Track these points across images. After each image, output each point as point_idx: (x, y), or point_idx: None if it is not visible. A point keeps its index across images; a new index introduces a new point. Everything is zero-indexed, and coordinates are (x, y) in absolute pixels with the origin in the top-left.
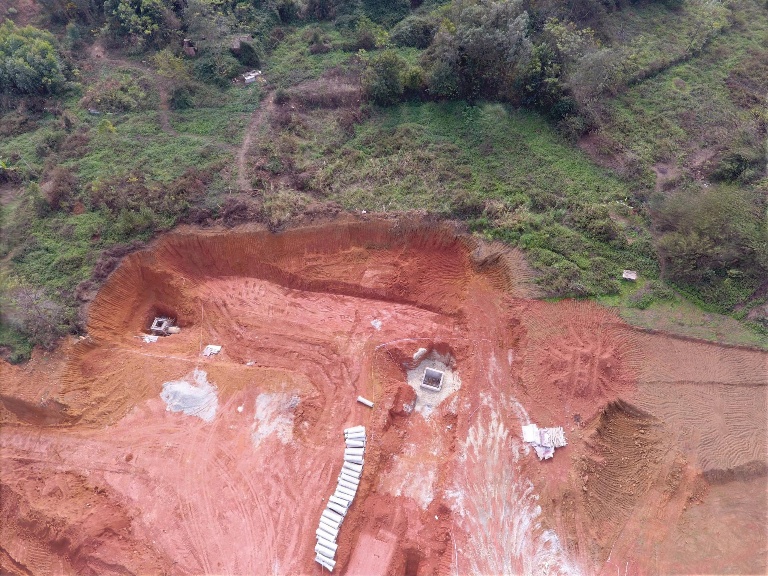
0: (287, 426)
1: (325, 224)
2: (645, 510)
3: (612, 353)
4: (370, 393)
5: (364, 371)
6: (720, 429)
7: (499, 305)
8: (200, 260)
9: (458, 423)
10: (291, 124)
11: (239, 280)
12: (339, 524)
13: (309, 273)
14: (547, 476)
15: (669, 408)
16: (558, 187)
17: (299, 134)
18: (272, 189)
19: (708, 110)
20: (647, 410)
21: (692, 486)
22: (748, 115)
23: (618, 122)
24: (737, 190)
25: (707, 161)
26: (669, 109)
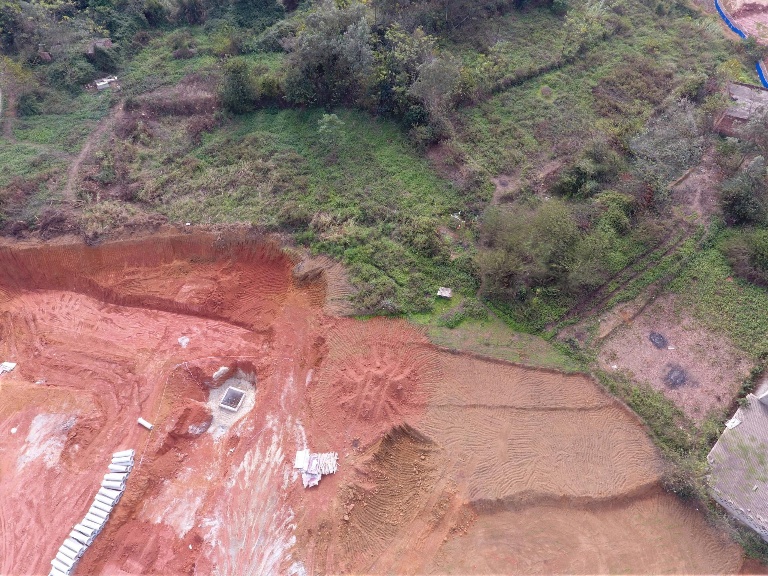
0: (56, 449)
1: (145, 237)
2: (404, 541)
3: (406, 375)
4: (154, 414)
5: (155, 391)
6: (500, 456)
7: (311, 322)
8: (16, 273)
9: (237, 447)
10: (135, 132)
11: (56, 294)
12: (77, 554)
13: (125, 287)
14: (308, 505)
15: (453, 433)
16: (392, 199)
17: (143, 142)
18: (97, 200)
19: (567, 120)
20: (430, 435)
21: (457, 516)
22: (607, 125)
23: (469, 132)
24: (575, 204)
25: (551, 173)
26: (527, 118)
